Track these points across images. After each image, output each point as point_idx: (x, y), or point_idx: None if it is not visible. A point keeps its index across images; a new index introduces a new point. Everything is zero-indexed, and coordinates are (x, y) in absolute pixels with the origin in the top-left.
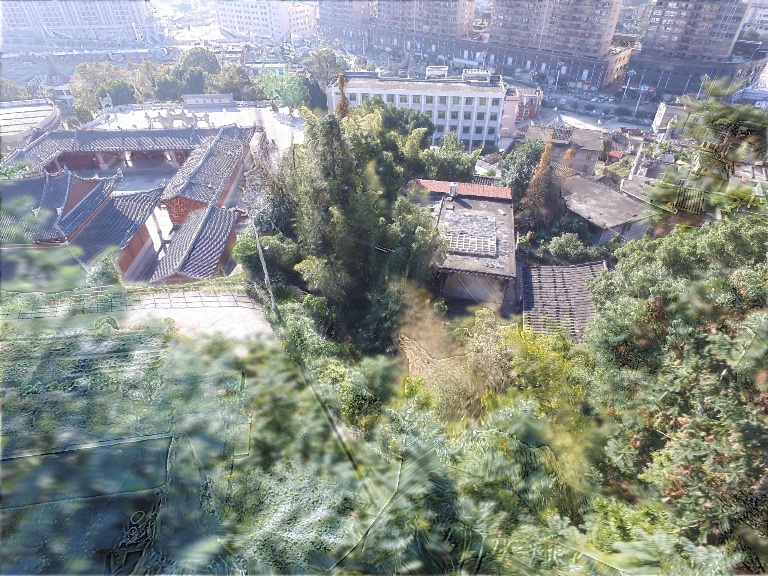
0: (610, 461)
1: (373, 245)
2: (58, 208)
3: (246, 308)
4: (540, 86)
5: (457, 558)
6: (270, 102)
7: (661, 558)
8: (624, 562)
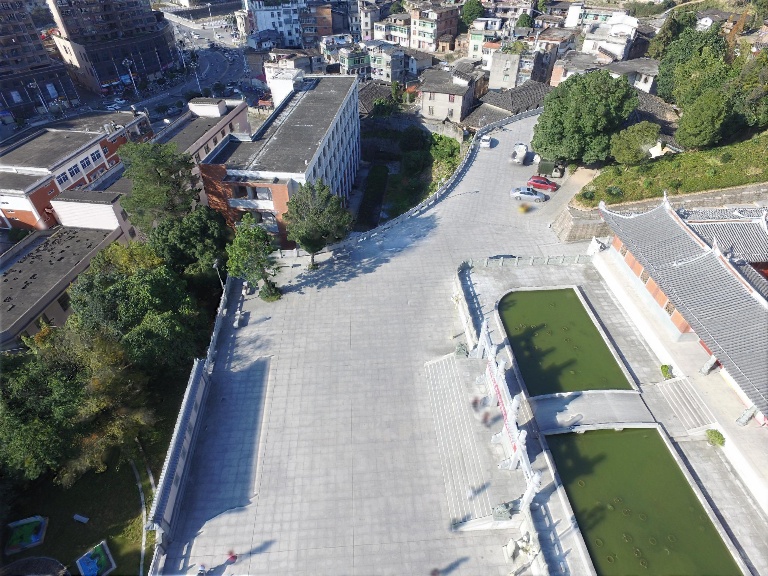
0: None
1: None
2: None
3: None
4: (18, 128)
5: None
6: (225, 302)
7: None
8: None
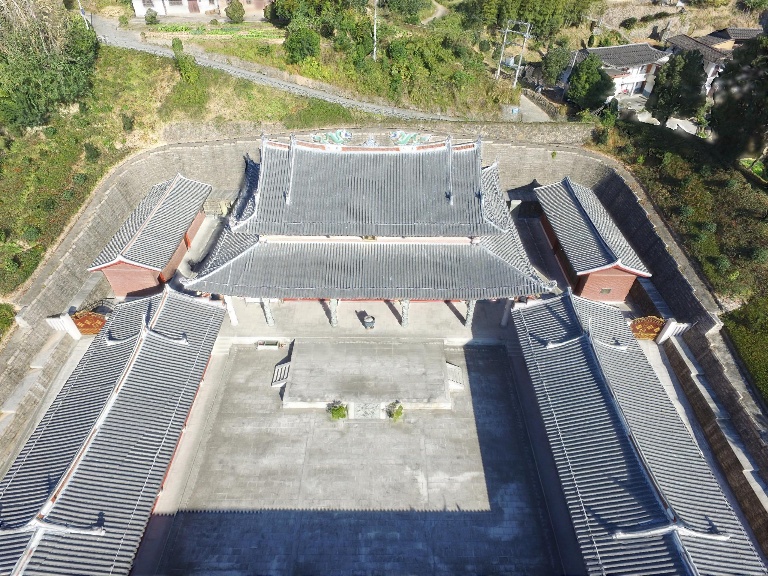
0: None
1: None
2: None
3: None
4: None
5: None
6: None
7: None
8: None
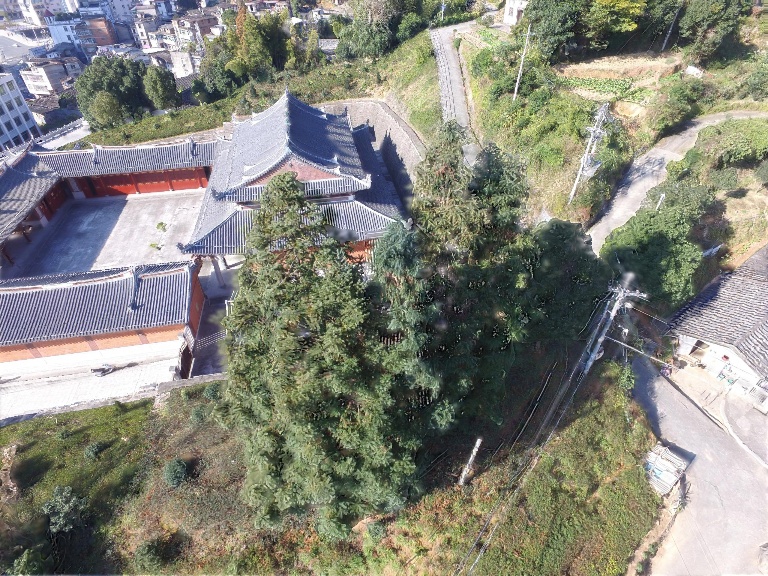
0: None
1: None
2: None
3: (438, 29)
4: None
5: None
6: None
7: None
8: None
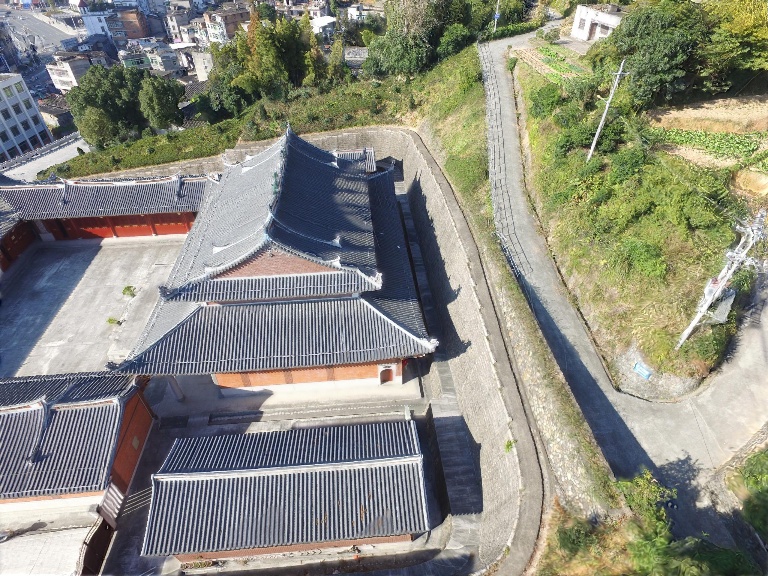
0: (524, 20)
1: (465, 6)
2: (334, 150)
3: None
4: None
5: (578, 2)
6: None
7: None
8: None
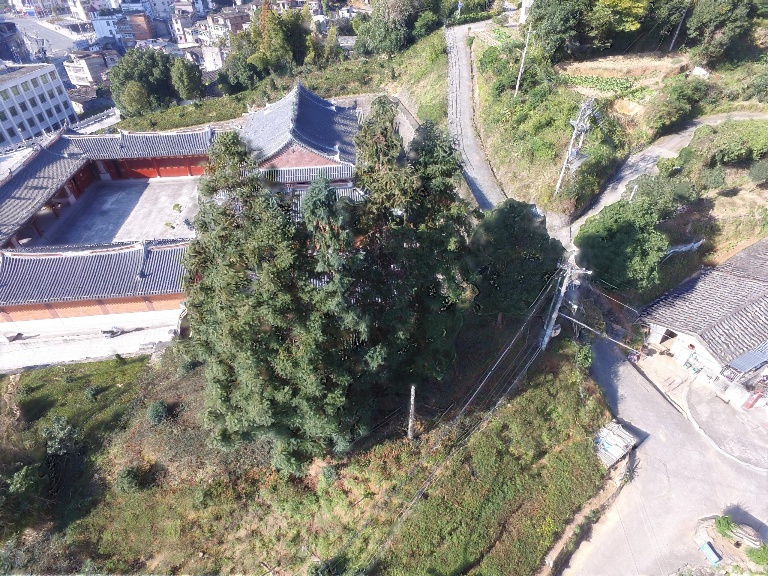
0: None
1: None
2: None
3: None
4: None
5: None
6: None
7: (509, 5)
8: (512, 6)
